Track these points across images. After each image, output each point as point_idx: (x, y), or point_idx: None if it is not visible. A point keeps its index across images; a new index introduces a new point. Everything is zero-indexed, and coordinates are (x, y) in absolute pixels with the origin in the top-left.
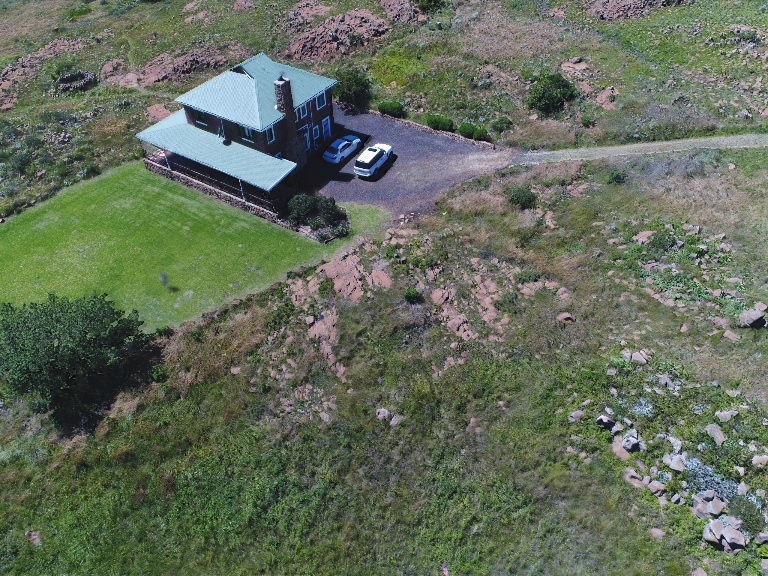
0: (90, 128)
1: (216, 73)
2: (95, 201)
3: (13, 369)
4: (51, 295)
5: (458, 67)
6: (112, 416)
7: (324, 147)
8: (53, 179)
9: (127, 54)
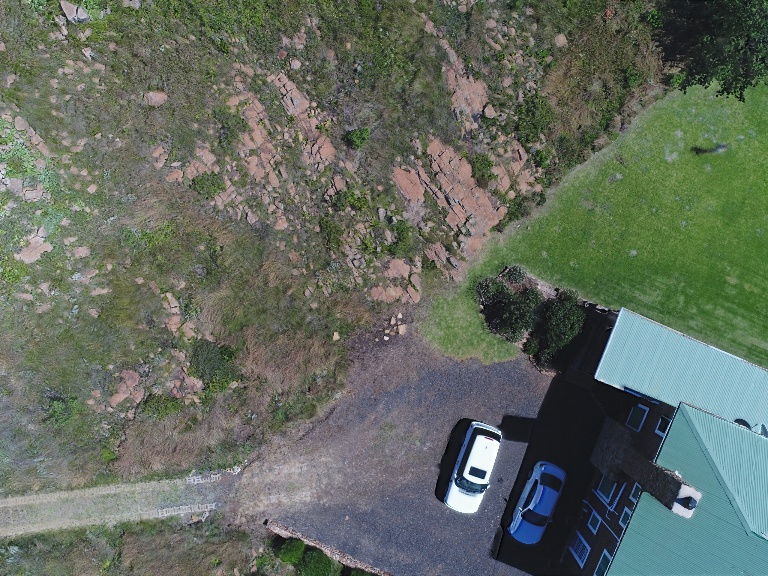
0: None
1: None
2: None
3: None
4: None
5: None
6: None
7: (573, 514)
8: None
9: None
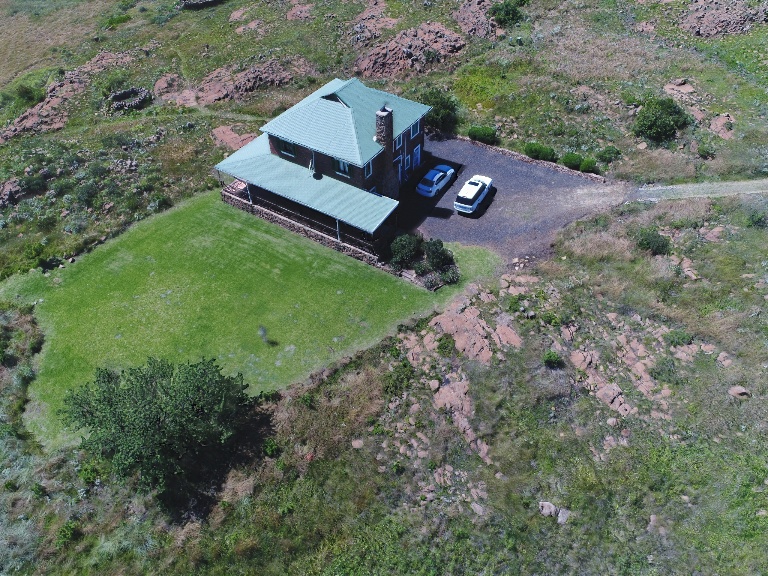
0: (155, 154)
1: (281, 91)
2: (171, 238)
3: (125, 454)
4: (151, 359)
5: (549, 88)
6: (226, 499)
7: (414, 178)
8: (123, 212)
9: (180, 68)
